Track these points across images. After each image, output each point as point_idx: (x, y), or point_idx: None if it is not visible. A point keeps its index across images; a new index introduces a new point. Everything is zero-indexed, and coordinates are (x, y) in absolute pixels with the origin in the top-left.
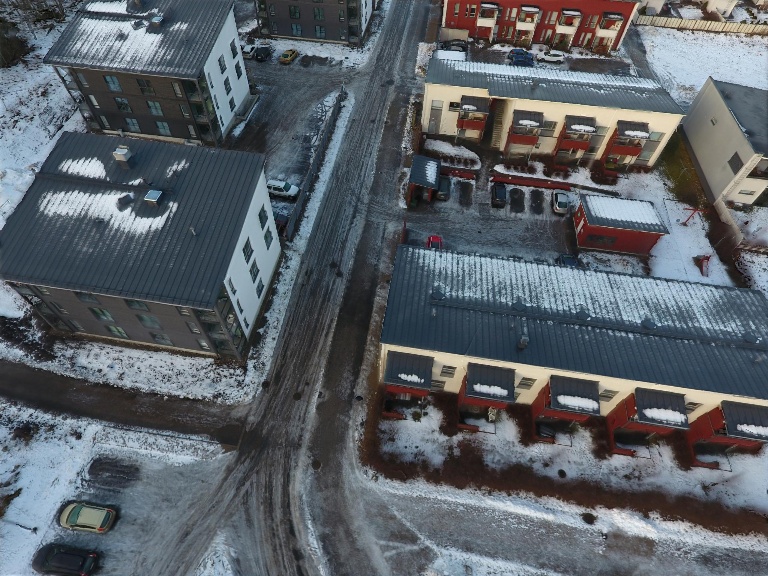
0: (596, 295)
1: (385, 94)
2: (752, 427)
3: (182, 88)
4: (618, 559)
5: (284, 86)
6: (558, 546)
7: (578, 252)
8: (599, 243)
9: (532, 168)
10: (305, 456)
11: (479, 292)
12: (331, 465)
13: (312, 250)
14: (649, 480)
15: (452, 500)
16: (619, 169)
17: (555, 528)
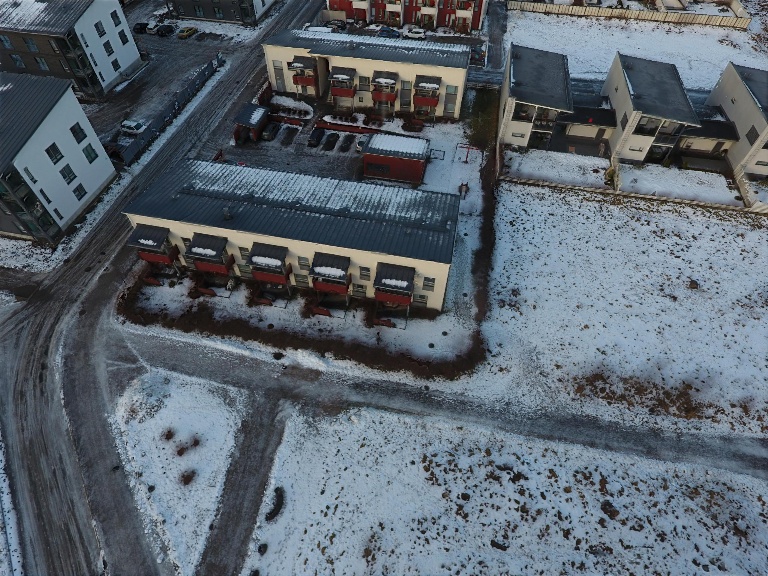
0: (317, 192)
1: (258, 62)
2: (393, 281)
3: (57, 45)
4: (287, 382)
5: (174, 55)
6: (244, 371)
7: (362, 179)
8: (379, 172)
9: (354, 118)
10: (77, 307)
11: (224, 187)
12: (93, 313)
13: (144, 173)
14: (336, 333)
15: (176, 339)
16: (428, 120)
17: (248, 360)
